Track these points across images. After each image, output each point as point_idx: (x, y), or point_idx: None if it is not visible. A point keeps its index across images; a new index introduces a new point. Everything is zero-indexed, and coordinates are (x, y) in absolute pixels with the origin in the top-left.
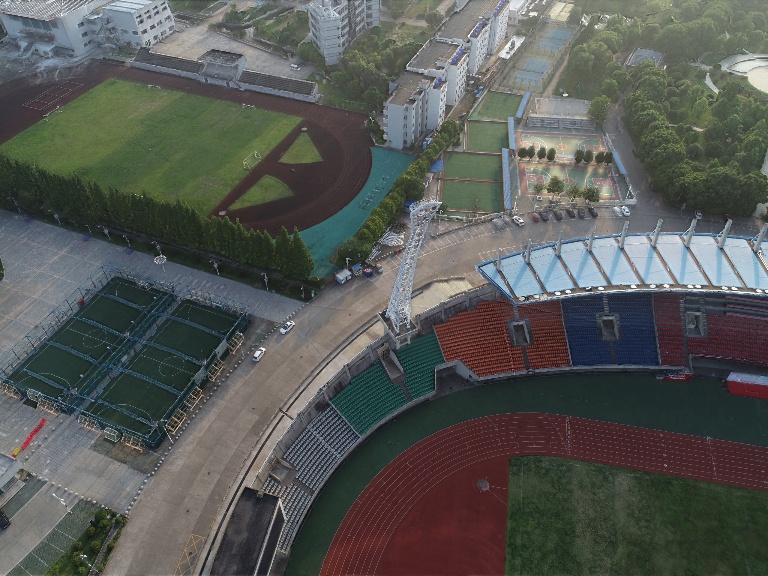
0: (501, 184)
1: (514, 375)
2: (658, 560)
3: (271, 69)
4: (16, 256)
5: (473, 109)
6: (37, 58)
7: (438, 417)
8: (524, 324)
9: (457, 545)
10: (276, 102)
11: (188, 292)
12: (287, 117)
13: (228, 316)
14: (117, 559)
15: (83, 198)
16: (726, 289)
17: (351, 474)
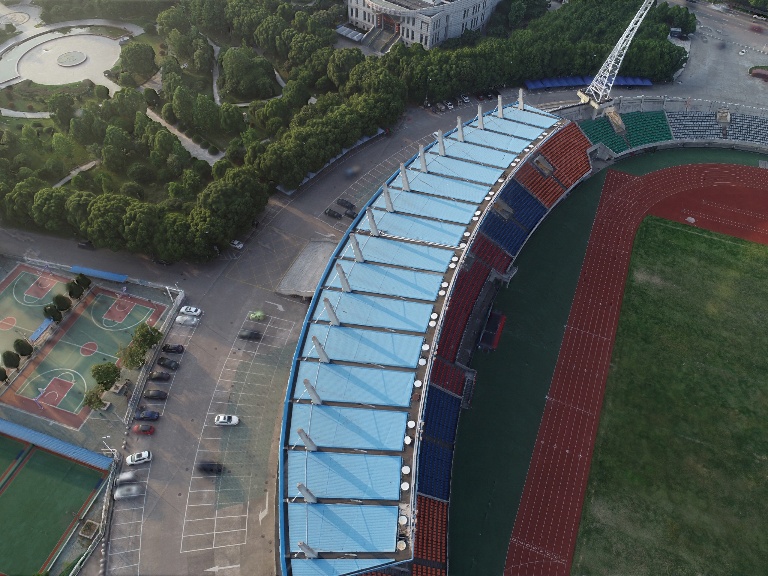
0: (35, 450)
1: None
2: (691, 520)
3: None
4: None
5: None
6: None
7: None
8: None
9: None
10: None
11: None
12: None
13: None
14: None
15: None
16: (445, 293)
17: None
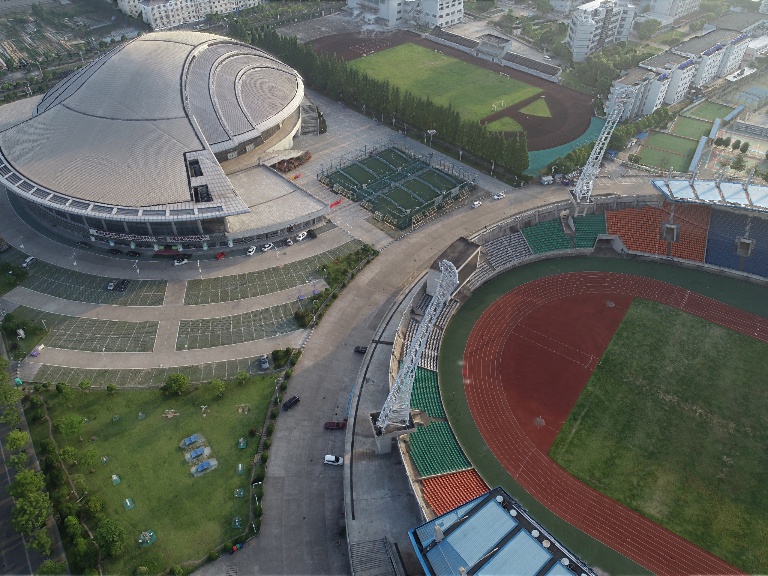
0: (692, 158)
1: (656, 257)
2: (725, 372)
3: (528, 56)
4: (335, 123)
5: (687, 109)
6: (362, 23)
7: (590, 265)
8: (675, 228)
9: (581, 323)
10: (526, 77)
11: (438, 165)
12: (532, 87)
13: (461, 182)
14: (371, 268)
15: (385, 98)
16: None
17: (521, 274)
